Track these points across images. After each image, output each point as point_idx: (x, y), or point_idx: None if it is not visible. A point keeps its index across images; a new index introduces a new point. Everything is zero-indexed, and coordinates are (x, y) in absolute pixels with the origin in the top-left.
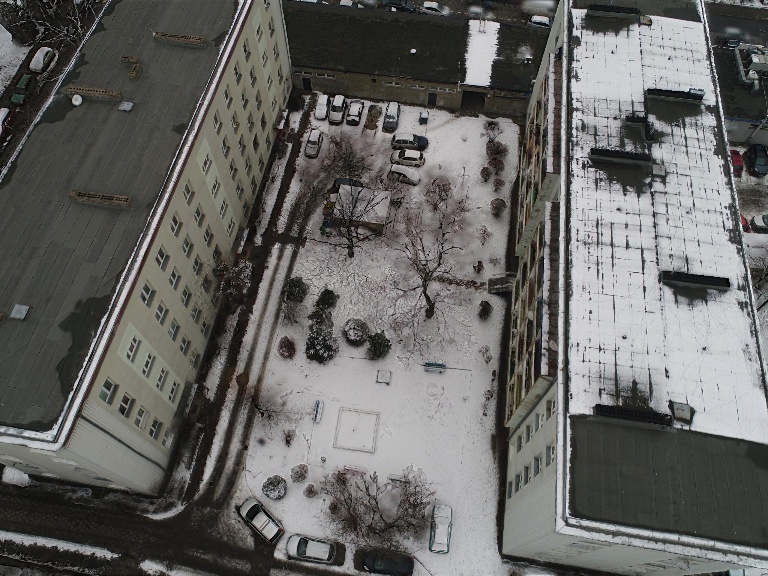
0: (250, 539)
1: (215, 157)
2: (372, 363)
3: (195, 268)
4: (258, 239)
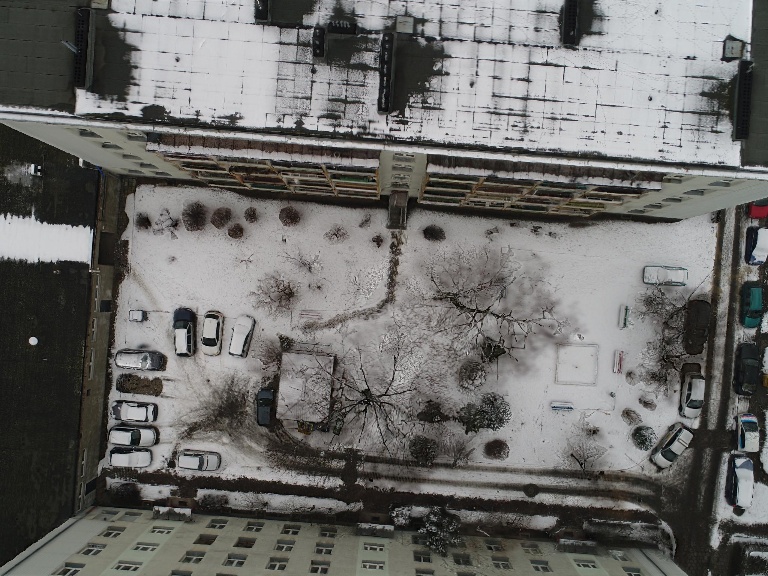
0: (685, 453)
1: None
2: (502, 355)
3: None
4: (354, 507)
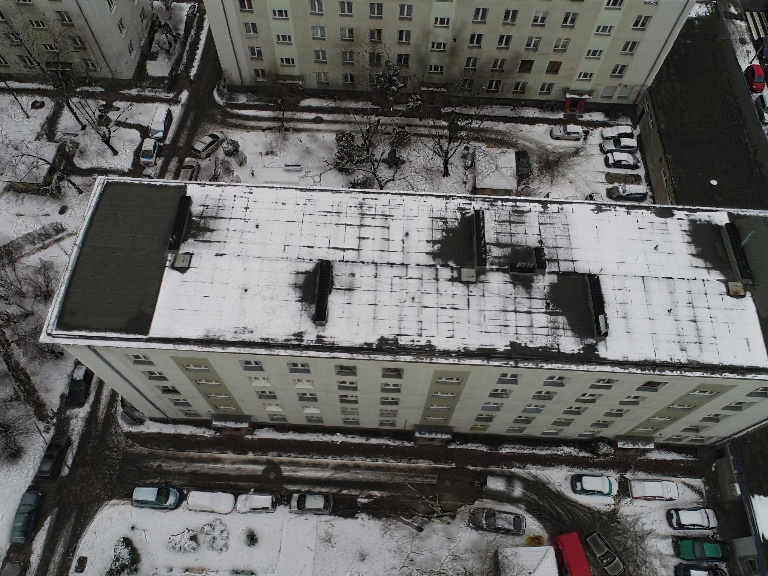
0: None
1: (460, 4)
2: None
3: (375, 37)
4: (448, 109)
